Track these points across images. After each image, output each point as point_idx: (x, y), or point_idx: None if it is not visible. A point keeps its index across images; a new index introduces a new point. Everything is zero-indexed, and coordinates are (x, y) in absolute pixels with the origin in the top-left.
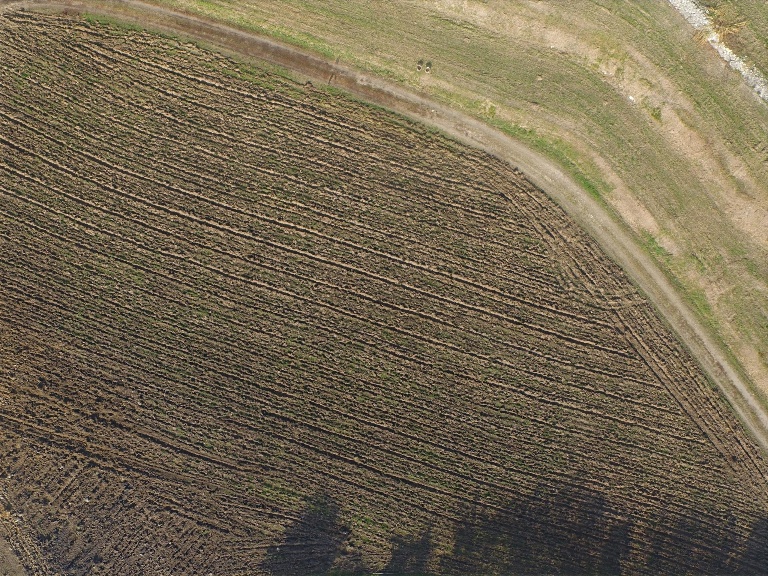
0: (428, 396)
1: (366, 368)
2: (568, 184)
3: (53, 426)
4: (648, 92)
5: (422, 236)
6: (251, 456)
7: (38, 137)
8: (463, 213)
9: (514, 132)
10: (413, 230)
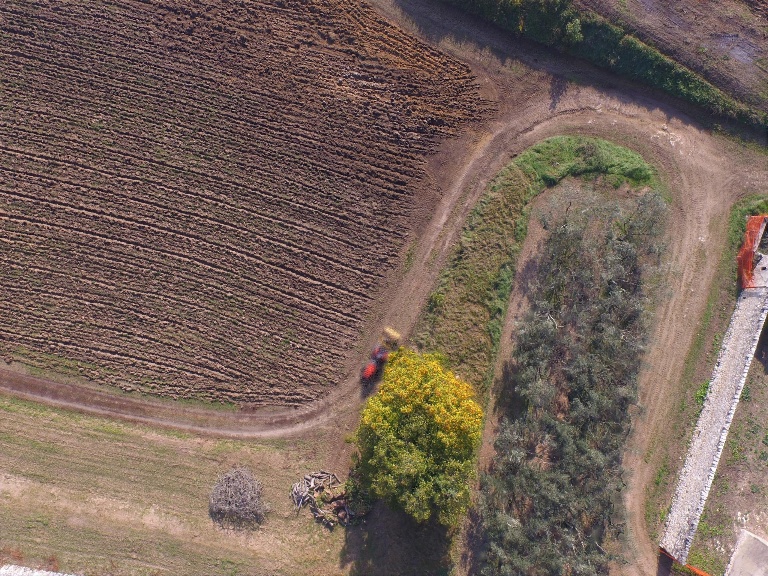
0: None
1: None
2: None
3: (230, 3)
4: None
5: None
6: None
7: (268, 282)
8: None
9: None
10: None
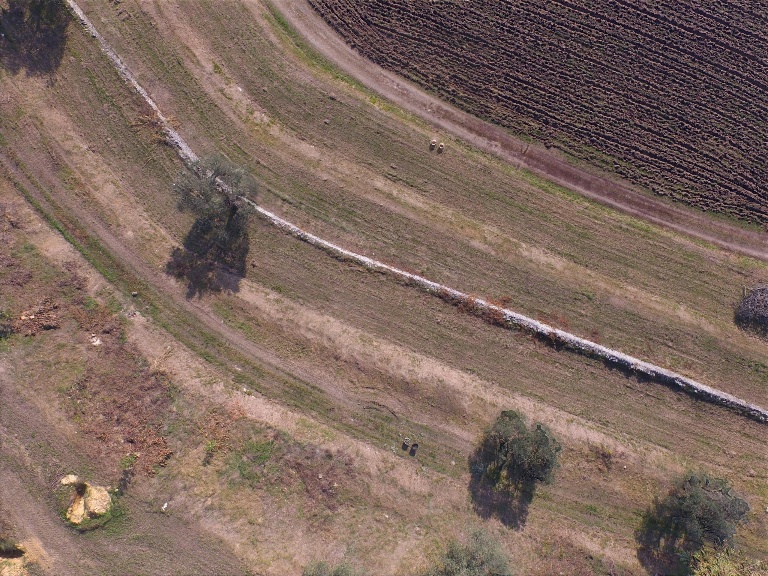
0: None
1: None
2: (303, 29)
3: None
4: (225, 87)
5: None
6: None
7: None
8: (409, 8)
9: (352, 82)
10: None
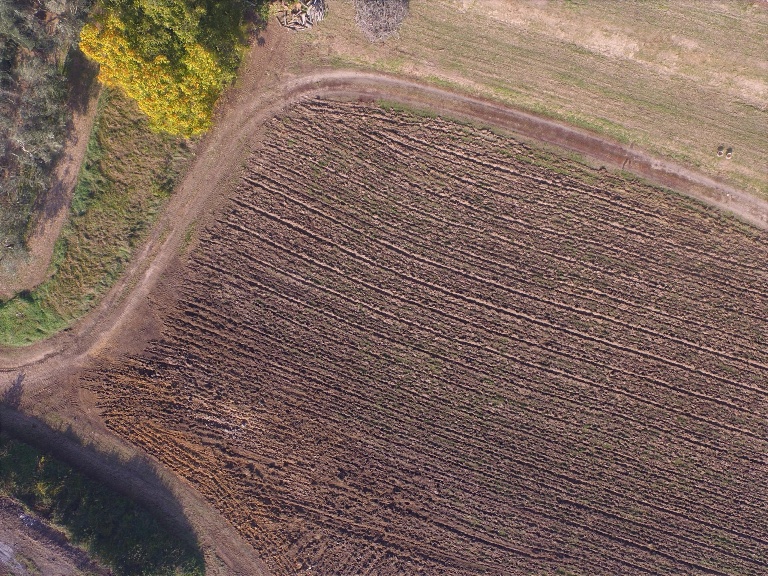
0: (722, 482)
1: (661, 454)
2: None
3: (352, 516)
4: None
5: (719, 322)
6: (545, 543)
7: (336, 226)
8: (760, 298)
9: None
10: (710, 316)
